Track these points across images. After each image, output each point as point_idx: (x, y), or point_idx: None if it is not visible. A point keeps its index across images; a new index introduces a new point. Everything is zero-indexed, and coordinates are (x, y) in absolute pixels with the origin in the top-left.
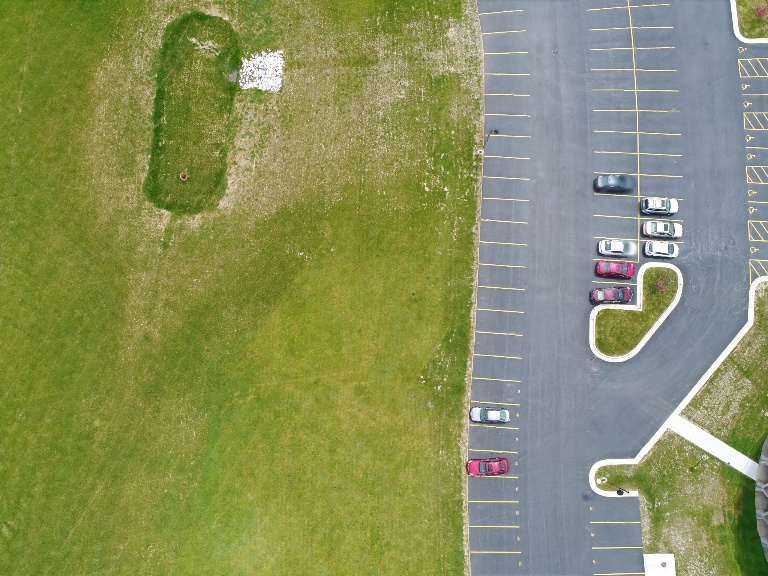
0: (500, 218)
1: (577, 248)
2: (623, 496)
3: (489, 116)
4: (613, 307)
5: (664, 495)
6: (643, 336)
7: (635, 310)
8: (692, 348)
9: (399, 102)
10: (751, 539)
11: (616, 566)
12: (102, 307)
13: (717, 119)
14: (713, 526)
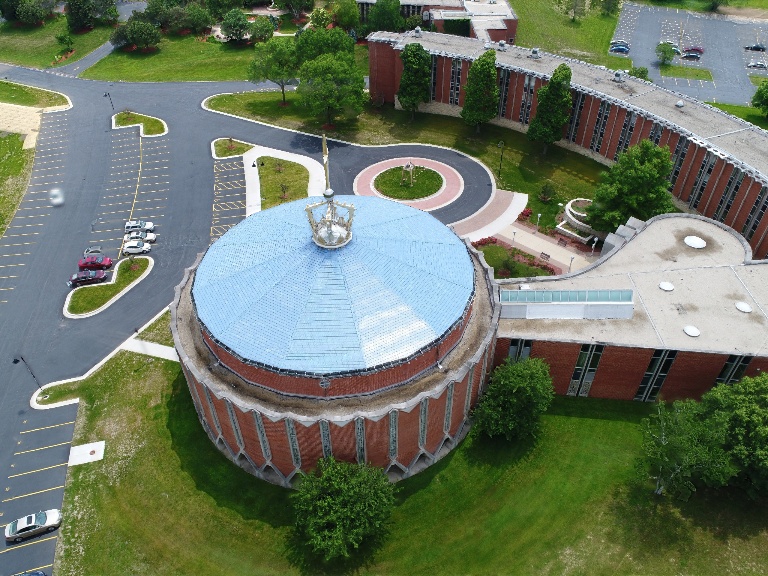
0: (7, 254)
1: (68, 260)
2: (62, 405)
3: (20, 210)
4: (89, 286)
5: (105, 396)
6: (112, 297)
7: (108, 284)
8: (154, 297)
9: None
10: (186, 409)
11: (37, 464)
12: None
13: (195, 189)
14: (149, 408)
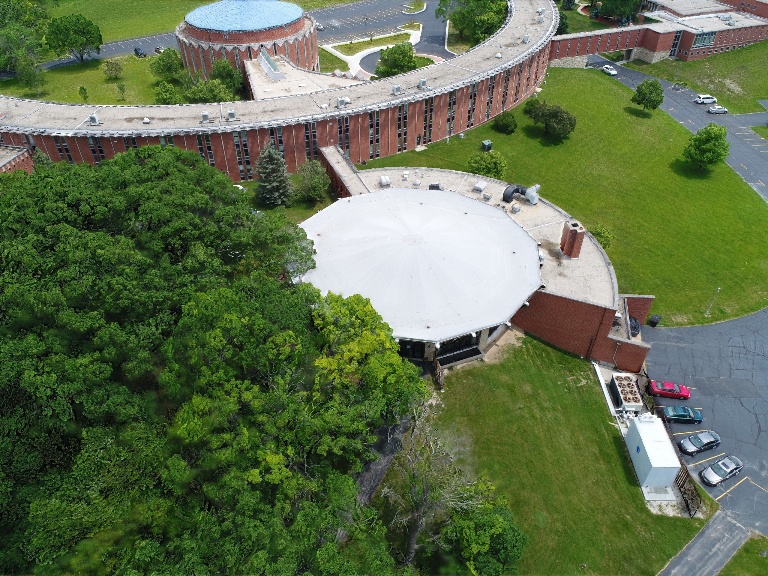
0: None
1: None
2: None
3: None
4: None
5: None
6: None
7: None
8: None
9: (308, 5)
10: None
11: None
12: (202, 0)
13: None
14: None
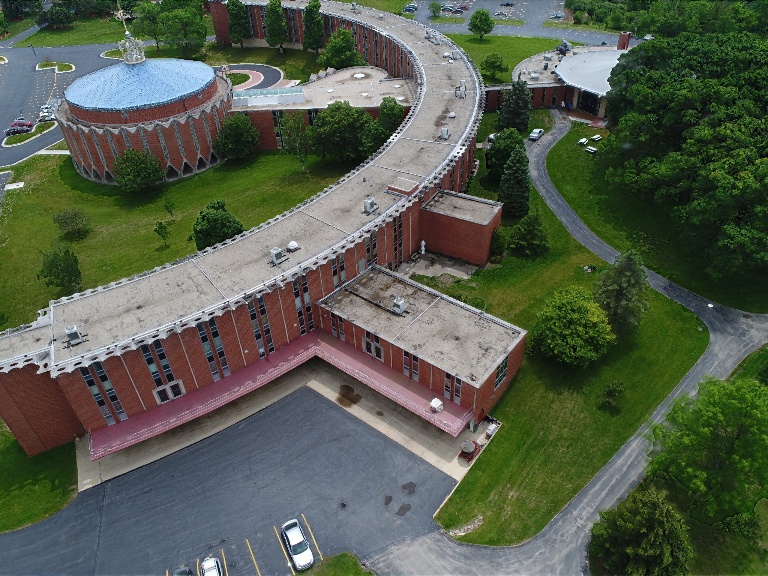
0: None
1: None
2: None
3: None
4: None
5: None
6: (31, 137)
7: None
8: None
9: None
10: None
11: None
12: None
13: None
14: None
